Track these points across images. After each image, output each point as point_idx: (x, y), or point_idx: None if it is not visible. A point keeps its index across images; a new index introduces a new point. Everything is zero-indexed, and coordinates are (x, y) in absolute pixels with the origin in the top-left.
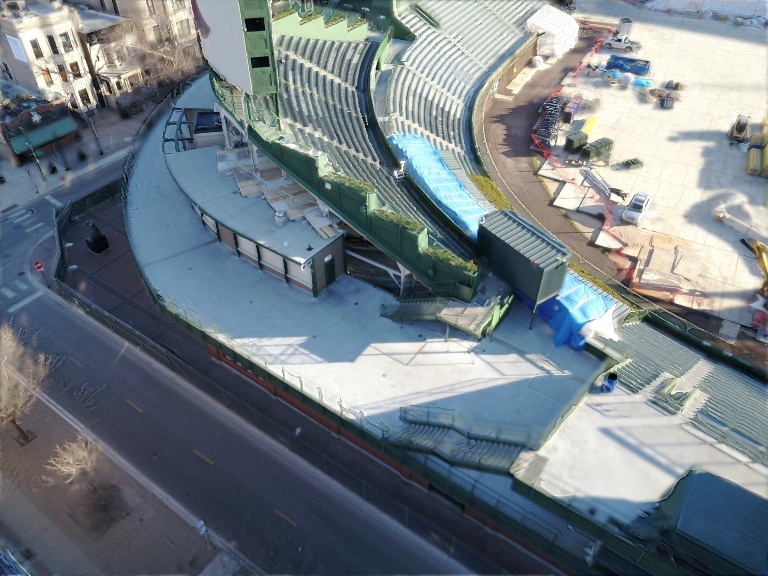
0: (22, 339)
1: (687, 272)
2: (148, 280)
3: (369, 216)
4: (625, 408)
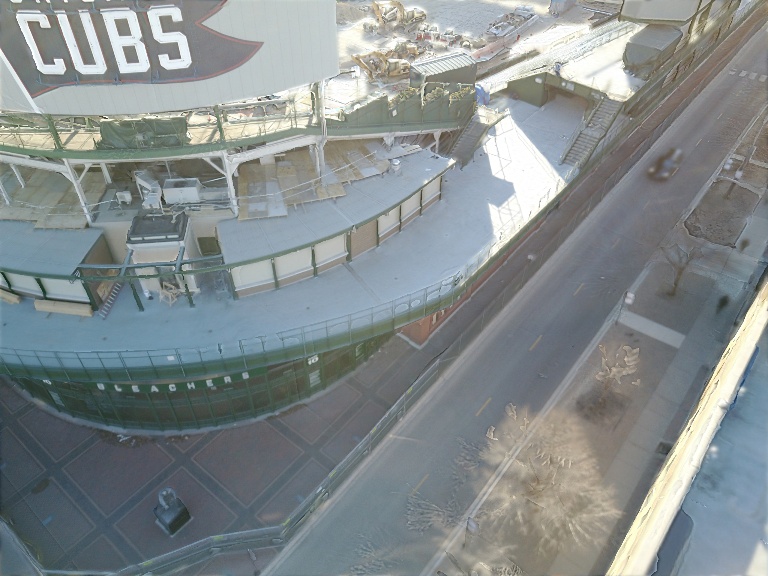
0: (374, 572)
1: (346, 99)
2: (441, 283)
3: (423, 109)
4: None
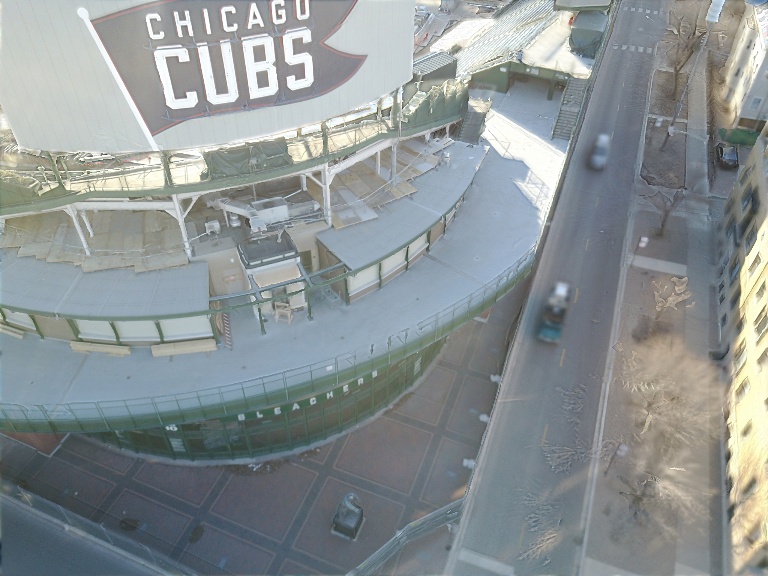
0: (546, 516)
1: None
2: None
3: None
4: (527, 59)
